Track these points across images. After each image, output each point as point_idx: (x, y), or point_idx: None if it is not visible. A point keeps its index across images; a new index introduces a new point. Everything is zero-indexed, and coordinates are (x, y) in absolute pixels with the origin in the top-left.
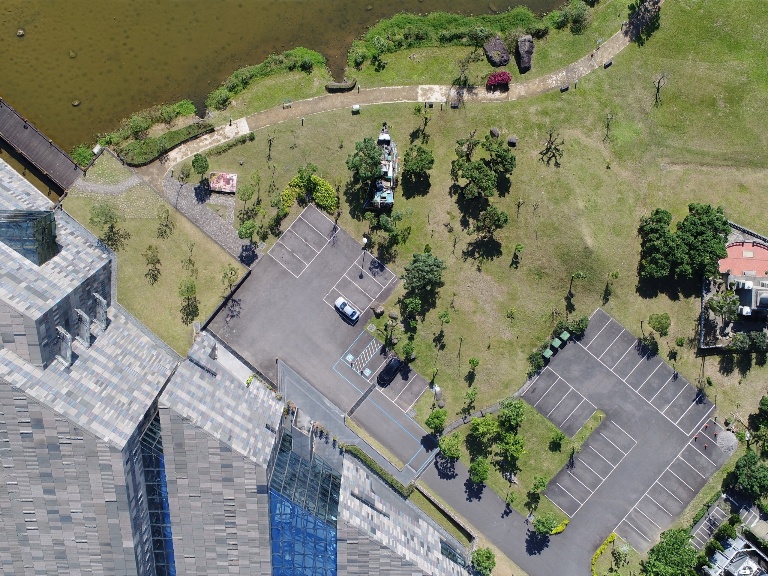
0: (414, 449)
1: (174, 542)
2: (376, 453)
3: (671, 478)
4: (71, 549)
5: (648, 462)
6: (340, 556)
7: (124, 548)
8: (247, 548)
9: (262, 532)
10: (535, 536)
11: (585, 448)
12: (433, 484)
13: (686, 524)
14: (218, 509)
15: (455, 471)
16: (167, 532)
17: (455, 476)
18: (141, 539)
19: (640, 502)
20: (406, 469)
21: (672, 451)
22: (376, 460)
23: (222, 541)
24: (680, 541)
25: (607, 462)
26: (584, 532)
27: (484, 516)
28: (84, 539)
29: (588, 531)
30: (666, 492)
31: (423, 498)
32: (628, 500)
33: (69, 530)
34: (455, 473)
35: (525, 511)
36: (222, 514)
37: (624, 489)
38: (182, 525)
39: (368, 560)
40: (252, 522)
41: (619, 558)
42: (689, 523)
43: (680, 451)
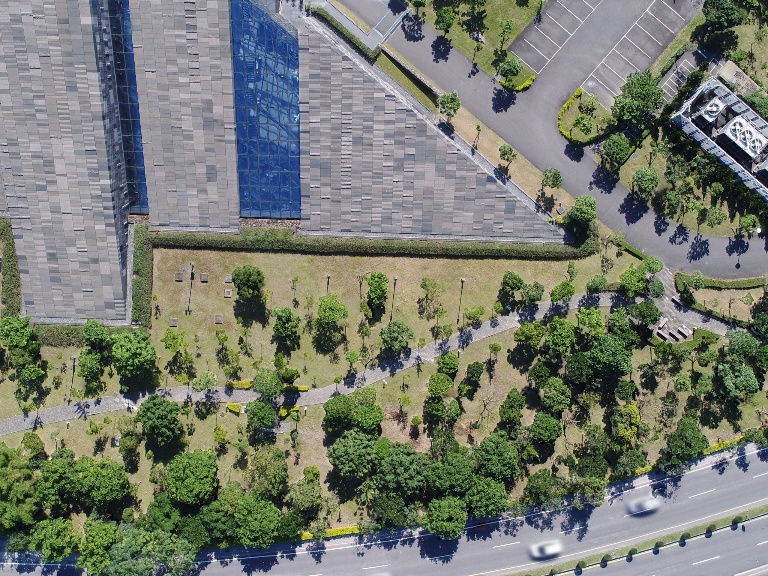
0: (381, 13)
1: (135, 52)
2: (343, 16)
3: (639, 33)
4: (29, 27)
5: (616, 17)
6: (302, 70)
7: (82, 26)
8: (208, 60)
9: (223, 38)
10: (502, 94)
11: (553, 3)
12: (400, 47)
13: (654, 77)
14: (178, 8)
15: (422, 33)
16: (128, 47)
17: (422, 38)
18: (100, 32)
19: (608, 57)
20: (373, 32)
21: (641, 5)
22: (343, 23)
23: (183, 50)
24: (646, 79)
25: (575, 17)
26: (551, 88)
27: (451, 76)
28: (42, 14)
29: (555, 87)
30: (634, 47)
31: (390, 62)
32: (596, 55)
33: (26, 2)
34: (422, 35)
35: (492, 70)
36: (182, 15)
37: (592, 44)
38: (142, 29)
39: (330, 75)
40: (213, 25)
41: (586, 113)
42: (657, 76)
43: (649, 6)
